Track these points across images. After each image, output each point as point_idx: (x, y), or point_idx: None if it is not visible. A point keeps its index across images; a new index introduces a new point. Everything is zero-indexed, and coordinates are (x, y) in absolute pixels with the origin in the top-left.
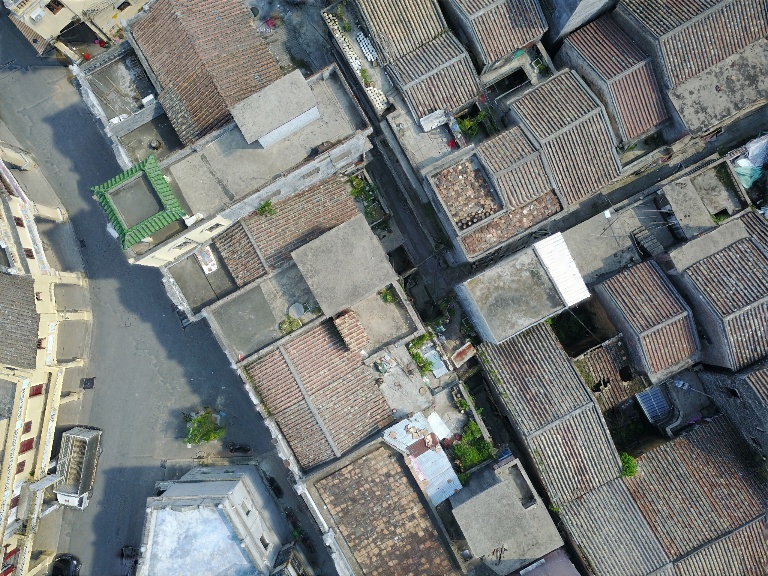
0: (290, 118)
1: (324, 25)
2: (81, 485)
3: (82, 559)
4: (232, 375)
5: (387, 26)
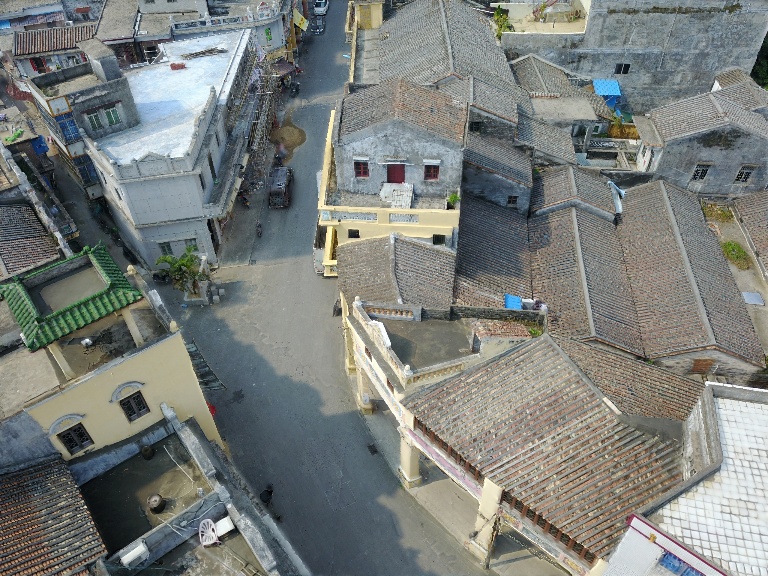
0: None
1: None
2: None
3: None
4: None
5: None
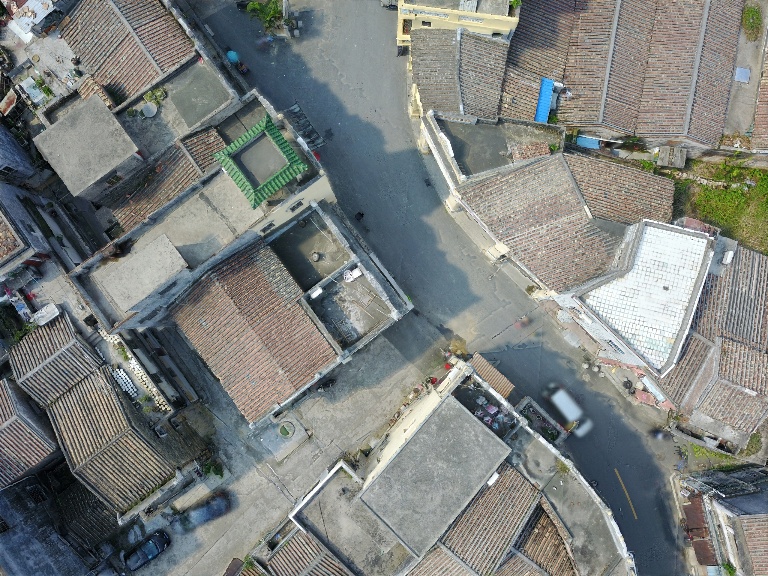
0: (127, 263)
1: (214, 426)
2: None
3: None
4: (266, 76)
5: (101, 402)
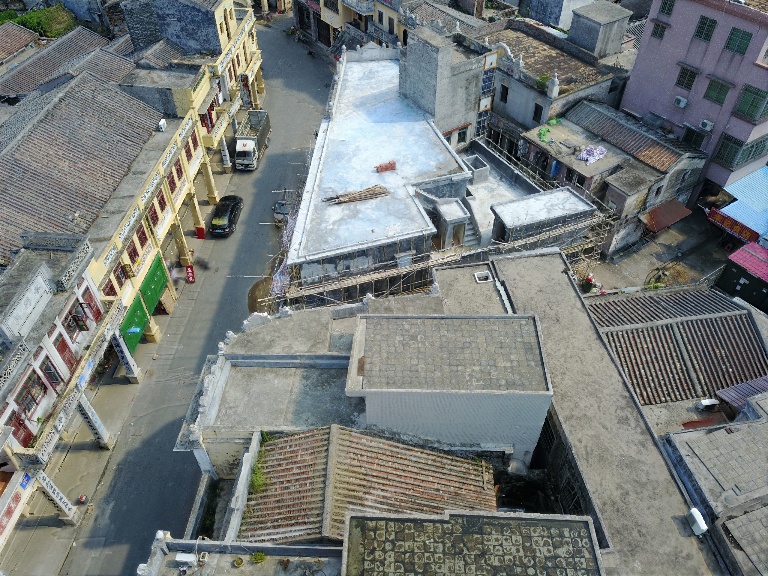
0: None
1: None
2: (259, 135)
3: (244, 204)
4: None
5: None
